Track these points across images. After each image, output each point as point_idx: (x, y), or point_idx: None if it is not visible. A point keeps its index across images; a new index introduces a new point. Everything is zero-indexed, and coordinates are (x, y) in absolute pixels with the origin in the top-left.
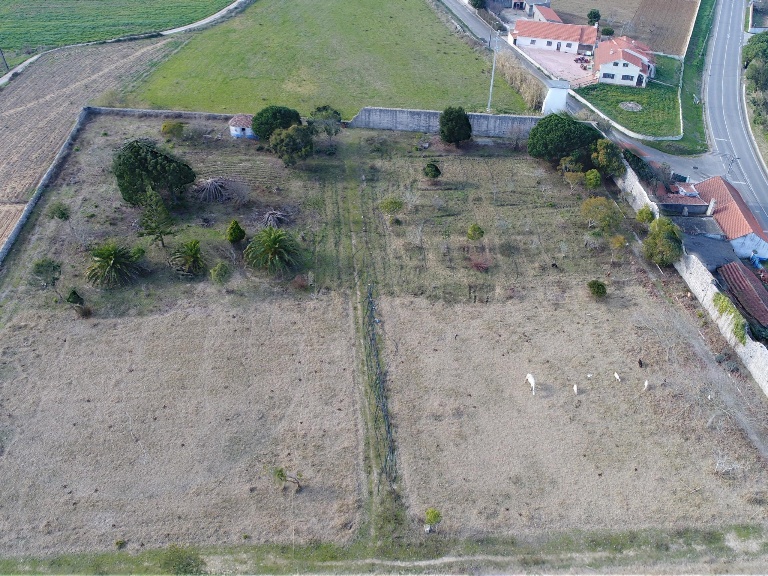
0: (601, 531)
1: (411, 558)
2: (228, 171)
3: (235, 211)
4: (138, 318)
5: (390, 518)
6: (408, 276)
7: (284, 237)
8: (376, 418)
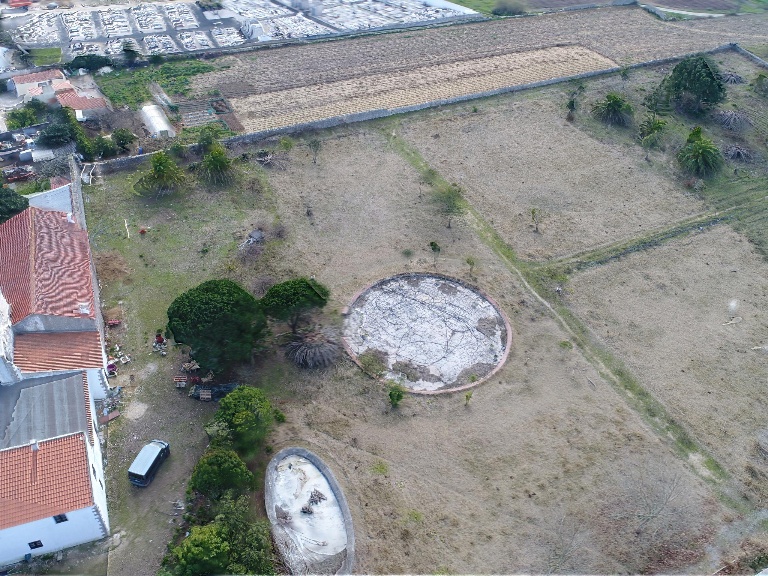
0: (634, 376)
1: (534, 287)
2: (759, 119)
3: (723, 136)
4: (587, 136)
5: (552, 273)
6: (767, 233)
7: (713, 151)
8: (617, 250)
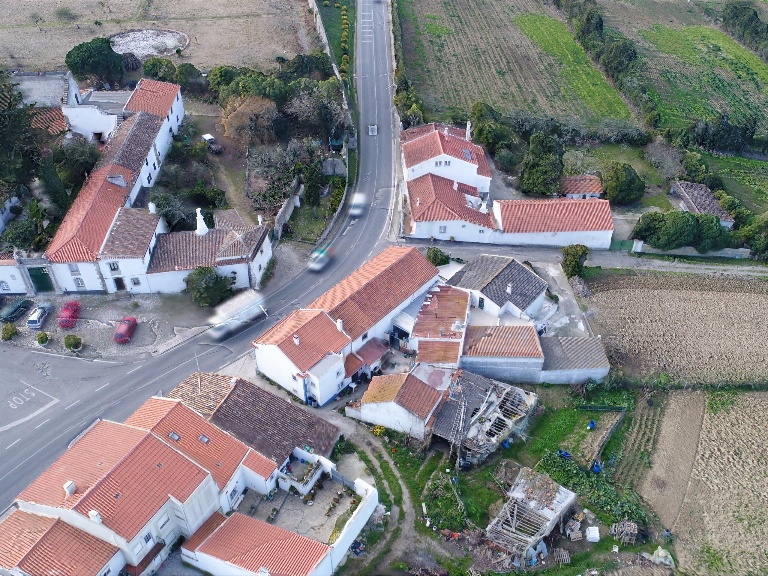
0: None
1: None
2: None
3: None
4: None
5: (143, 16)
6: None
7: None
8: None
